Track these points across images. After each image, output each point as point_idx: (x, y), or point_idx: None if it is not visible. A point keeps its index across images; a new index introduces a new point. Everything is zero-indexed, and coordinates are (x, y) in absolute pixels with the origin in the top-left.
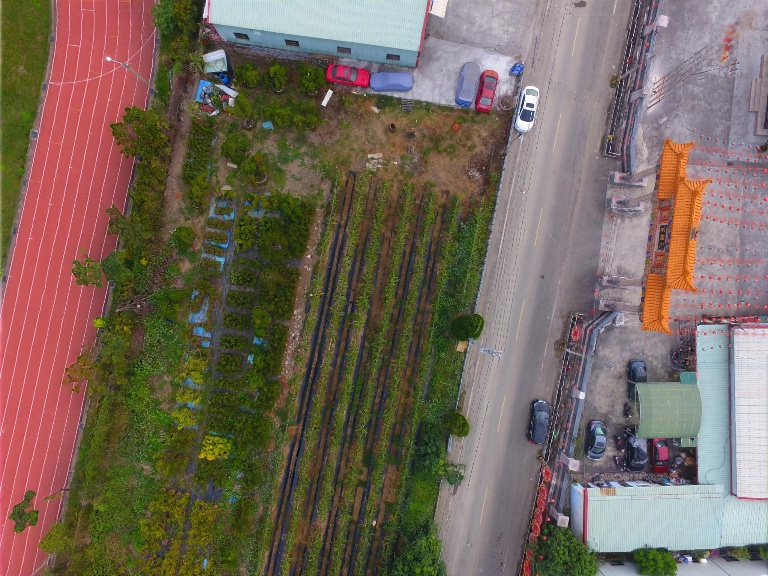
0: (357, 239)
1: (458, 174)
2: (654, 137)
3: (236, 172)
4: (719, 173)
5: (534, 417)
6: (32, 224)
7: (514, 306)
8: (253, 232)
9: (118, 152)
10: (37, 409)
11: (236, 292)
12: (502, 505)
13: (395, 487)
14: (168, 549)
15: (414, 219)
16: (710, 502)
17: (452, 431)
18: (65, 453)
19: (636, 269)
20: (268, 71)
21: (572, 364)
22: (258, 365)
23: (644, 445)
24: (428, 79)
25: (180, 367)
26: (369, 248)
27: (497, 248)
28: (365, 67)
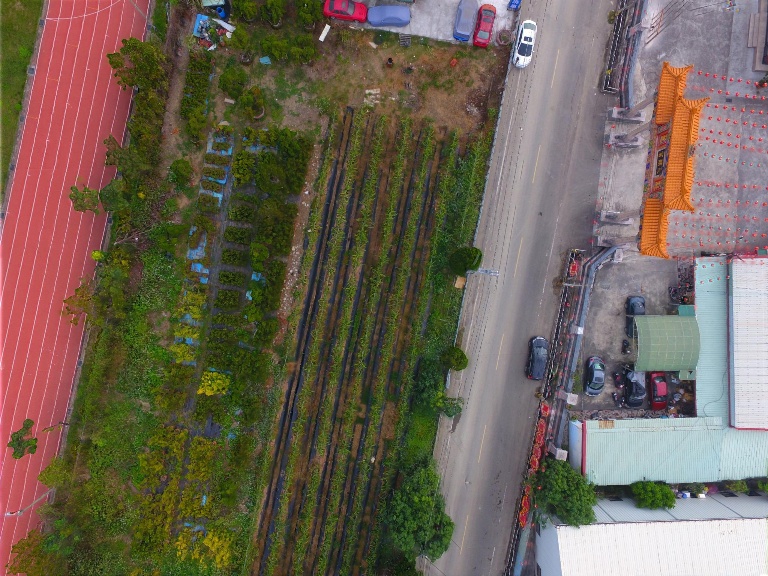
0: (355, 173)
1: (456, 110)
2: (652, 73)
3: (234, 107)
4: (717, 109)
5: (532, 353)
6: (30, 161)
7: (512, 243)
8: (251, 167)
9: (115, 88)
10: (36, 346)
11: (234, 228)
12: (501, 443)
13: (394, 424)
14: (167, 484)
15: (412, 155)
16: (708, 434)
17: (450, 365)
18: (64, 390)
19: (634, 206)
20: (265, 5)
21: (570, 301)
22: (256, 299)
23: (642, 380)
24: (426, 14)
25: (178, 303)
26: (367, 182)
27: (495, 185)
28: (362, 2)
